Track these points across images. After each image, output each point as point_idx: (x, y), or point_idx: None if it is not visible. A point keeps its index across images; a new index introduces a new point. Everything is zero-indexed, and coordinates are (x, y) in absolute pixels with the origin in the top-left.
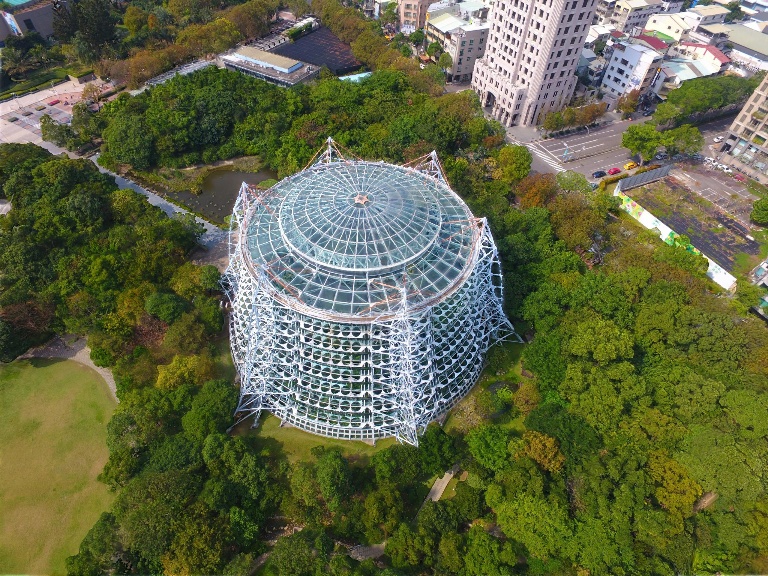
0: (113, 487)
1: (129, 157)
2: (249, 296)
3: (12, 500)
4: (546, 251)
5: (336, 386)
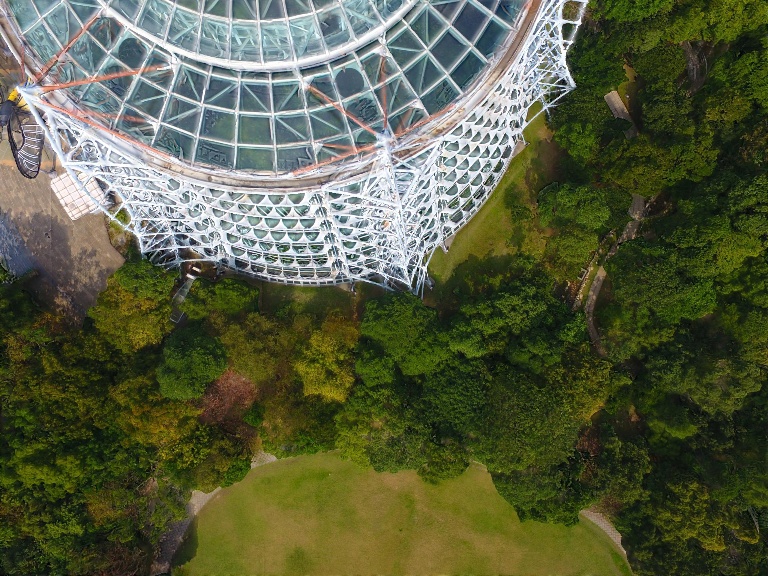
0: None
1: None
2: (307, 215)
3: None
4: None
5: None
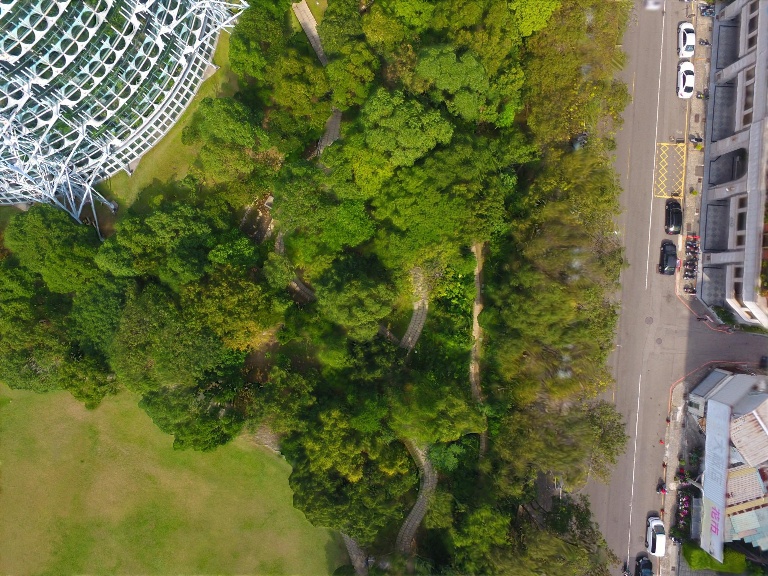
0: (110, 391)
1: None
2: None
3: (72, 508)
4: None
5: (103, 53)
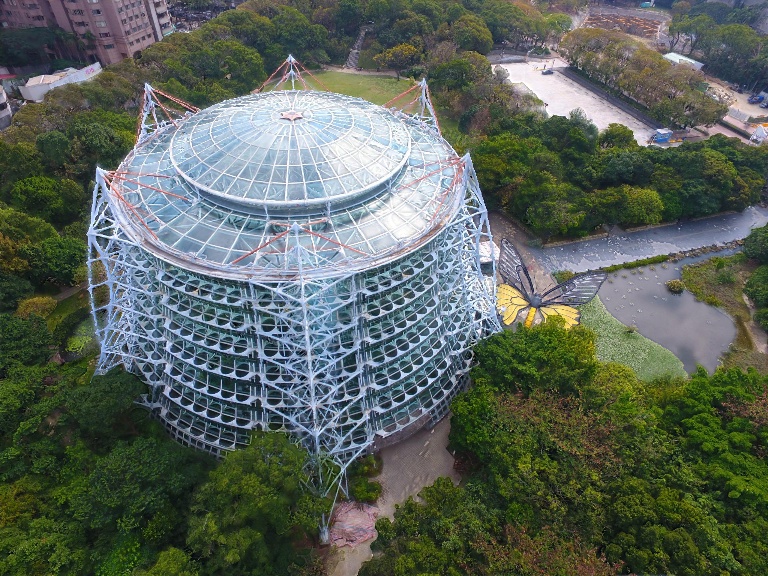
0: None
1: (760, 231)
2: None
3: None
4: (53, 575)
5: None
